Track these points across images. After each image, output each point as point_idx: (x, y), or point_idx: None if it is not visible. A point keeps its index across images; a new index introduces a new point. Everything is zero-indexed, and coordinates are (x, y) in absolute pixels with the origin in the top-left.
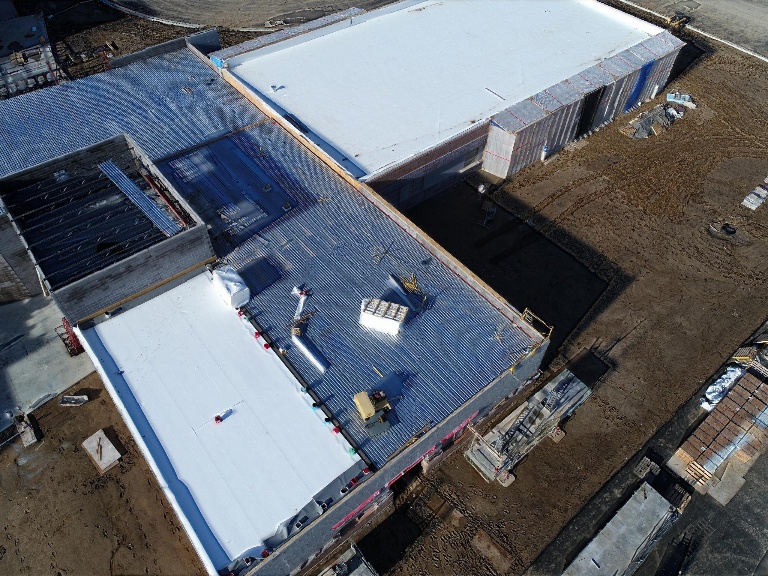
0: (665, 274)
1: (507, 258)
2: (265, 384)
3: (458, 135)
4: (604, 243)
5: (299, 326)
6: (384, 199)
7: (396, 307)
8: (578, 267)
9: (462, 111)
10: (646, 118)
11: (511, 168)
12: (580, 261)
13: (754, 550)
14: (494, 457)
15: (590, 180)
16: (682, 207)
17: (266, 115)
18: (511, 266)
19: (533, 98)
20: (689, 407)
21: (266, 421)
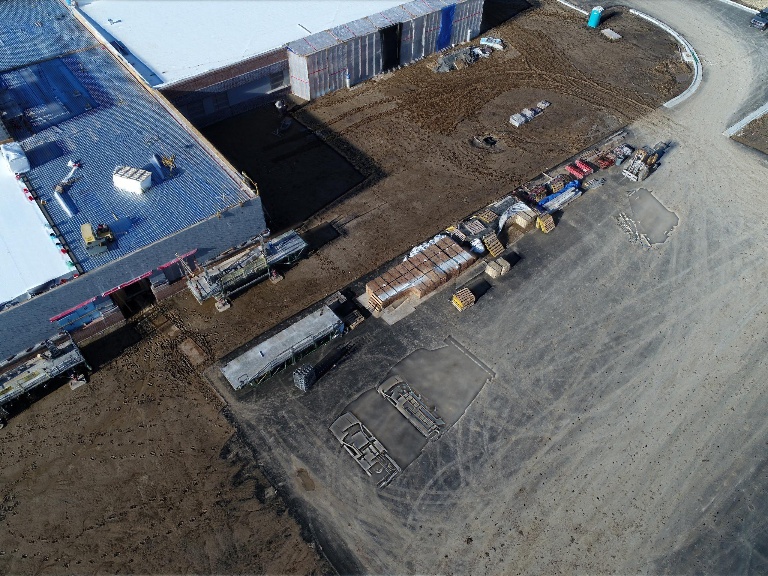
0: (418, 172)
1: (288, 158)
2: (20, 222)
3: (254, 57)
4: (376, 149)
5: (64, 187)
6: (168, 101)
7: (142, 172)
8: (346, 166)
9: (270, 41)
10: (450, 55)
11: (314, 91)
12: (349, 161)
13: (400, 353)
14: (207, 285)
15: (384, 103)
16: (456, 124)
17: (100, 43)
18: (289, 164)
19: (330, 30)
20: (393, 262)
21: (11, 245)
